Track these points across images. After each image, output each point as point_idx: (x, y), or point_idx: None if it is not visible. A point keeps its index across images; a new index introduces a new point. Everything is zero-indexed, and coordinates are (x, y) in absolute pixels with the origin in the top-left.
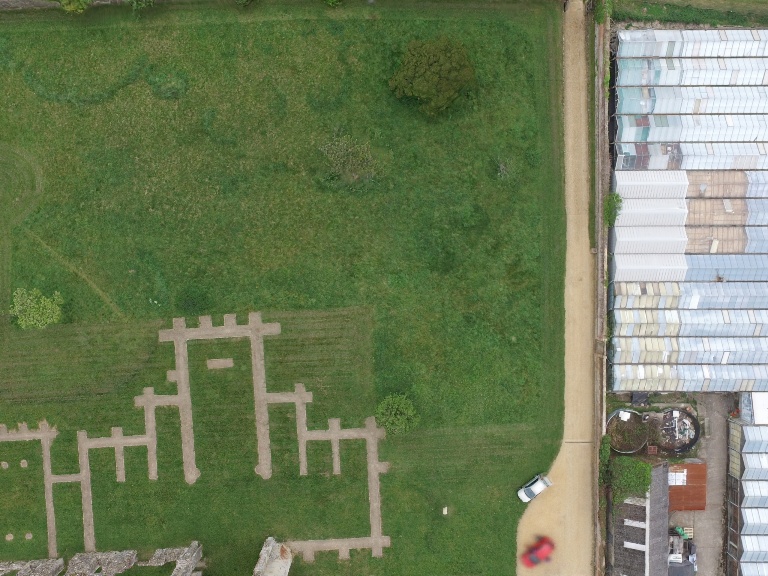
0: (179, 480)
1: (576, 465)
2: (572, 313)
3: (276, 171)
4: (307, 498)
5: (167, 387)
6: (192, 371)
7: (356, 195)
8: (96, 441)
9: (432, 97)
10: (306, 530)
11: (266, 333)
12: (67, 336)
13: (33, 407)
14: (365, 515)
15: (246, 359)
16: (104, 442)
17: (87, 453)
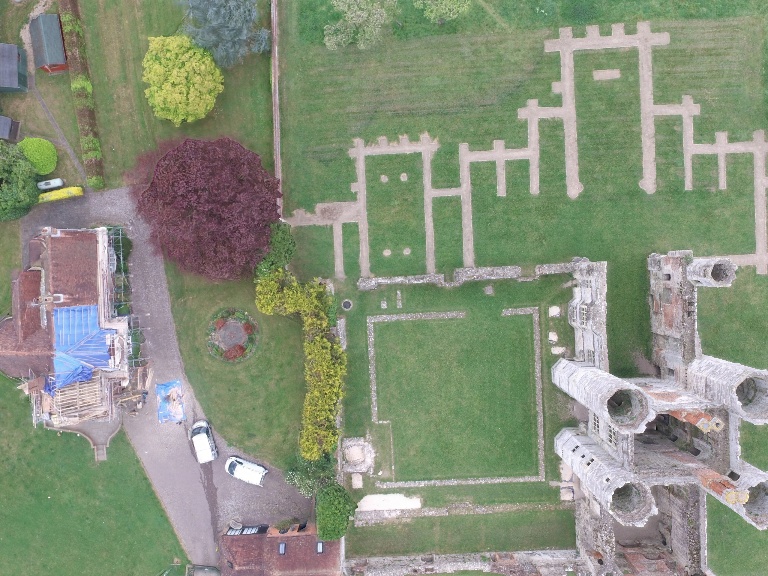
0: (561, 194)
1: None
2: None
3: None
4: (691, 213)
5: (552, 99)
6: (578, 82)
7: None
8: (477, 154)
9: None
10: (689, 246)
11: (654, 43)
12: (450, 47)
13: (414, 119)
14: (751, 231)
15: (634, 70)
16: (485, 156)
17: (468, 166)
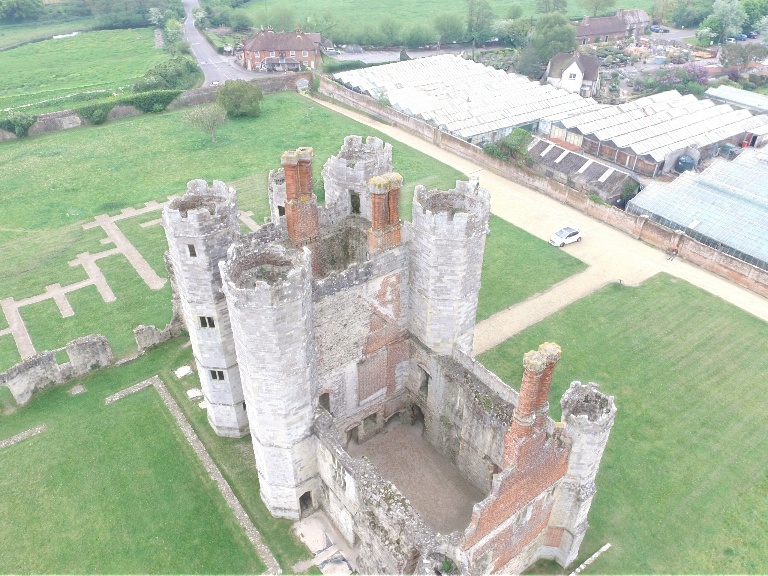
0: (144, 291)
1: (488, 178)
2: (408, 142)
3: (154, 154)
4: None
5: (103, 247)
6: (126, 233)
7: (221, 147)
8: (27, 301)
9: (243, 94)
10: None
11: None
12: None
13: None
14: None
15: None
16: (38, 299)
17: (16, 311)
